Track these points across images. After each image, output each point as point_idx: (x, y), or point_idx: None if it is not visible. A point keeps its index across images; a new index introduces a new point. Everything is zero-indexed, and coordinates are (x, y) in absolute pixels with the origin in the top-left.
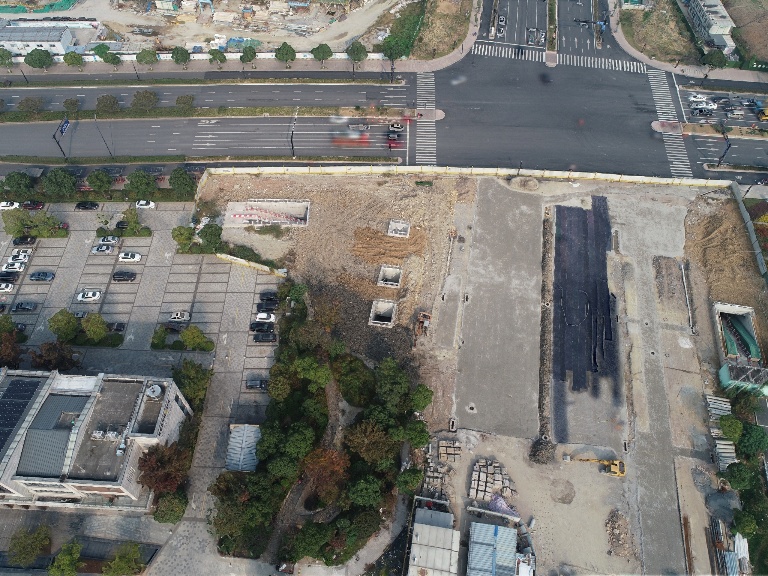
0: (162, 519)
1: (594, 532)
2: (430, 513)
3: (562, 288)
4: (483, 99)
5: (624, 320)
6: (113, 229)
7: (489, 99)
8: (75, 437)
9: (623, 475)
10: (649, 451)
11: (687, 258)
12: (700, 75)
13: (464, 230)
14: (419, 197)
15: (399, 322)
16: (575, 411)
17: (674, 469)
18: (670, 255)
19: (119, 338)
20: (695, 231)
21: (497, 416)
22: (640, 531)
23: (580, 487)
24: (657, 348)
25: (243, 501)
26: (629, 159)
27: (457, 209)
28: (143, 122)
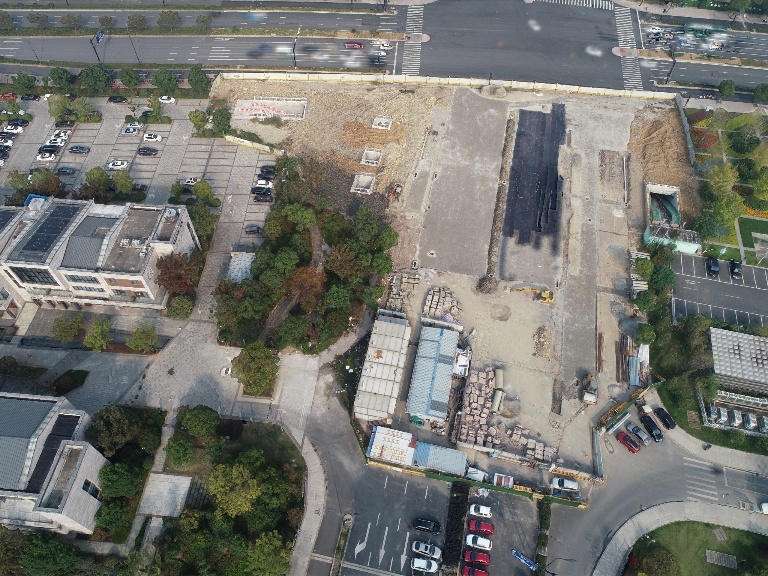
0: (174, 312)
1: (523, 340)
2: (389, 319)
3: (518, 171)
4: (465, 27)
5: (568, 196)
6: (139, 117)
7: (470, 27)
8: (107, 241)
9: (552, 301)
10: (577, 288)
11: (629, 152)
12: (661, 12)
13: (438, 126)
14: (401, 99)
15: (376, 190)
16: (518, 258)
17: (596, 301)
18: (615, 149)
19: (142, 194)
20: (639, 132)
21: (452, 260)
22: (562, 342)
23: (516, 310)
24: (594, 216)
25: (239, 298)
26: (588, 76)
27: (434, 110)
28: (167, 38)
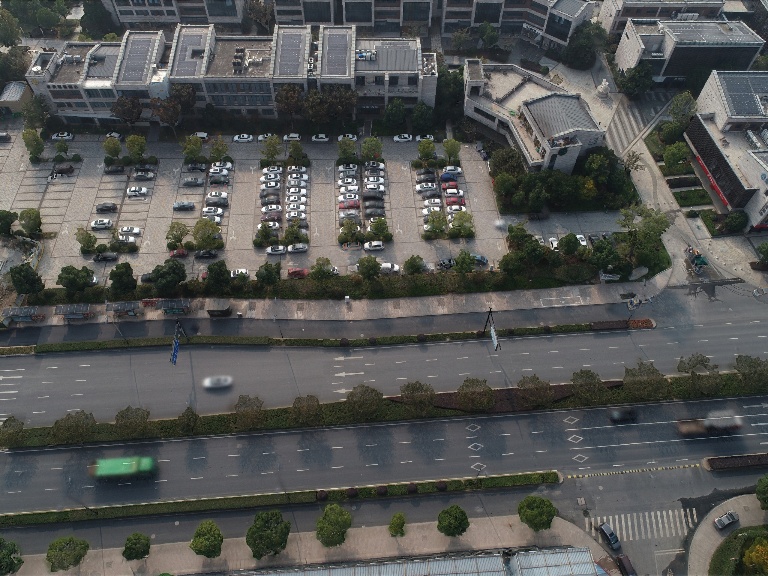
0: None
1: None
2: None
3: None
4: None
5: None
6: None
7: None
8: None
9: None
10: None
11: None
12: None
13: None
14: None
15: None
16: None
17: None
18: None
19: None
20: None
21: None
22: None
23: None
24: None
25: None
26: None
27: None
28: None
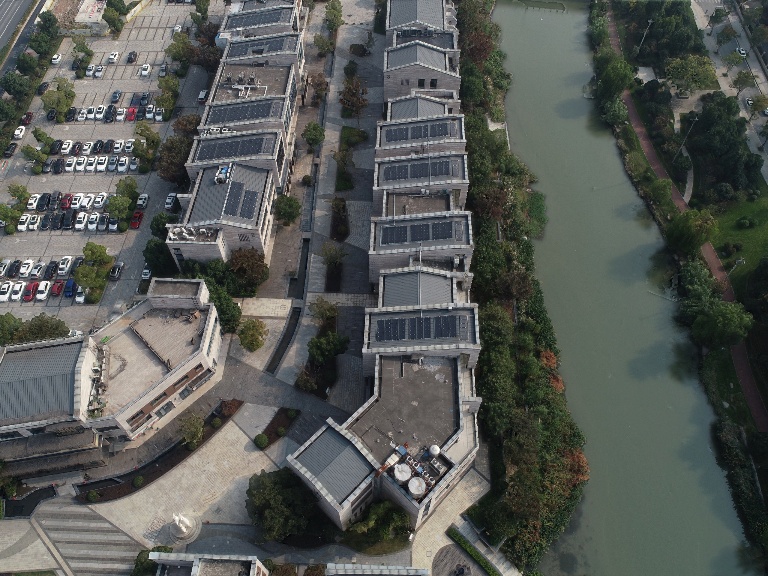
0: None
1: None
2: None
3: None
4: None
5: None
6: None
7: None
8: None
9: None
10: None
11: None
12: None
13: None
14: None
15: None
16: None
17: None
18: None
19: None
20: None
21: None
22: None
23: None
24: None
25: None
26: None
27: None
28: None
